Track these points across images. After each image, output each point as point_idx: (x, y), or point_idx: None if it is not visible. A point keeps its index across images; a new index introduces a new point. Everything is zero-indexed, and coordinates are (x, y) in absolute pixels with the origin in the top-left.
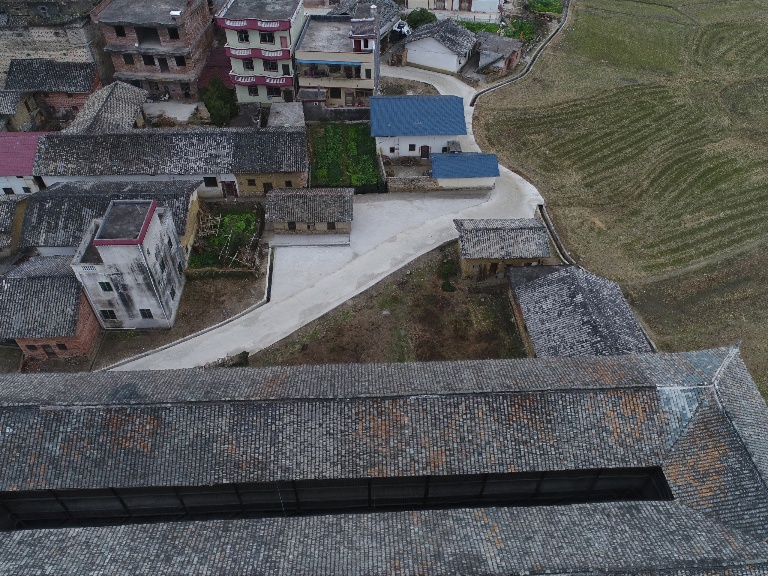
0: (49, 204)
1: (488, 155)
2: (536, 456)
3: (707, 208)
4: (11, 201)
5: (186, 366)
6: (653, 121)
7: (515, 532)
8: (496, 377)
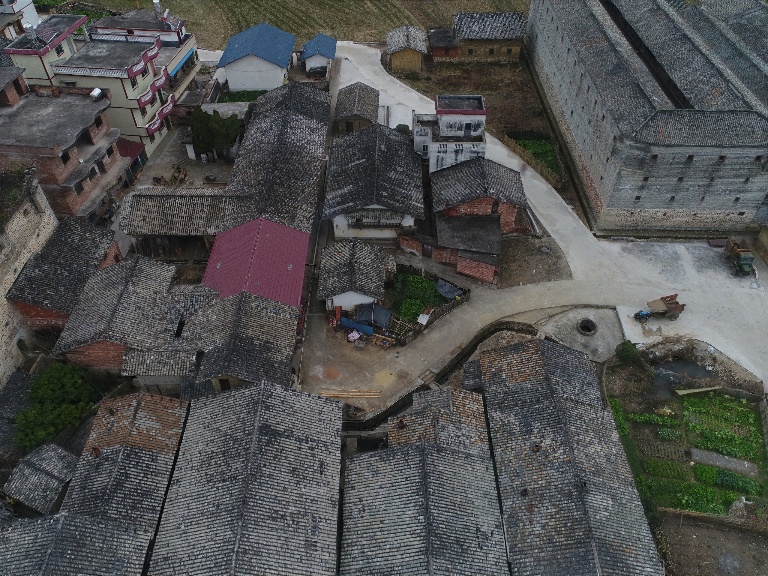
0: (384, 193)
1: (320, 35)
2: (599, 5)
3: (361, 4)
4: (354, 239)
5: (508, 160)
6: (262, 0)
7: (634, 8)
8: (569, 3)
